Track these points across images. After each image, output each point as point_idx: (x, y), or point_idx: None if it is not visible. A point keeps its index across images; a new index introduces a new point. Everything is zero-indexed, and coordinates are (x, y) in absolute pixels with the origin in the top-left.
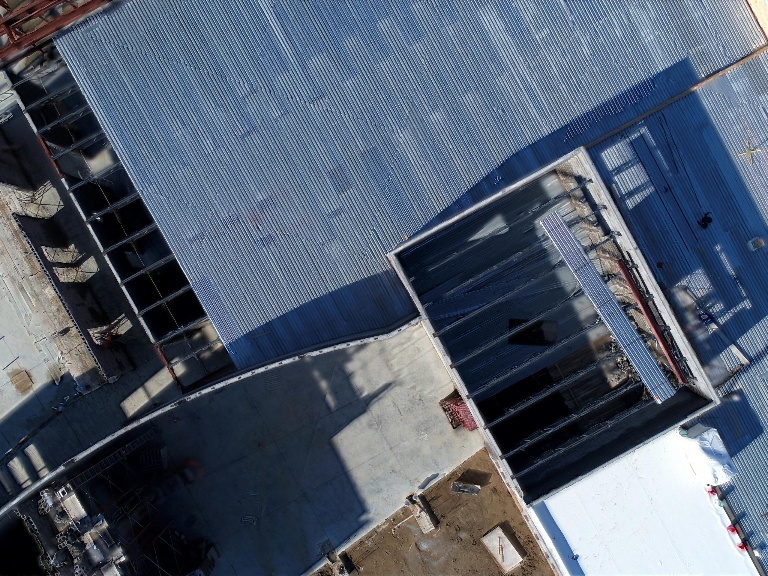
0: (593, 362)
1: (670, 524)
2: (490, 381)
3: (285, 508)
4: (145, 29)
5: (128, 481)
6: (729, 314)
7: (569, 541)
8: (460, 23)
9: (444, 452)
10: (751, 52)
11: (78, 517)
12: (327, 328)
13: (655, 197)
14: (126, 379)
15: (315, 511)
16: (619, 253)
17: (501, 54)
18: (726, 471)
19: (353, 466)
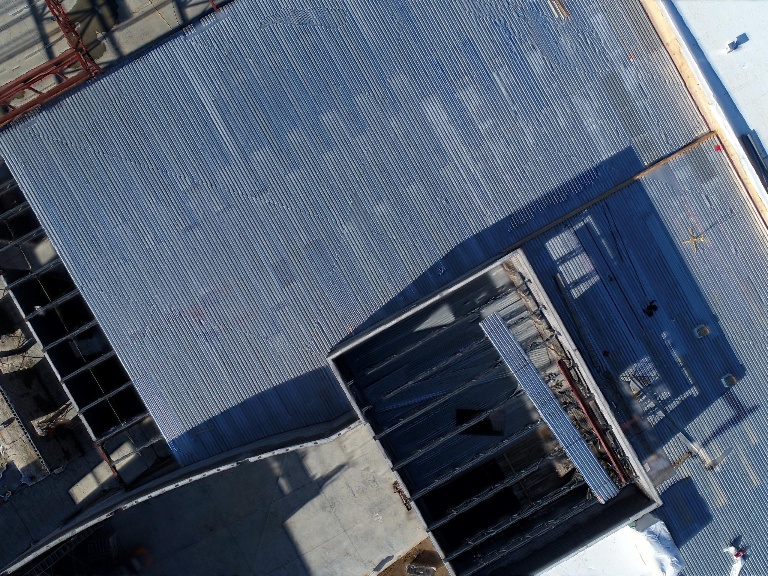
0: (541, 452)
1: None
2: (432, 484)
3: None
4: (84, 124)
5: (75, 574)
6: (676, 402)
7: None
8: (402, 114)
9: (399, 534)
10: (693, 140)
11: None
12: (272, 423)
13: (600, 286)
14: (75, 465)
15: None
16: (562, 349)
17: (444, 145)
18: (674, 565)
19: (307, 550)
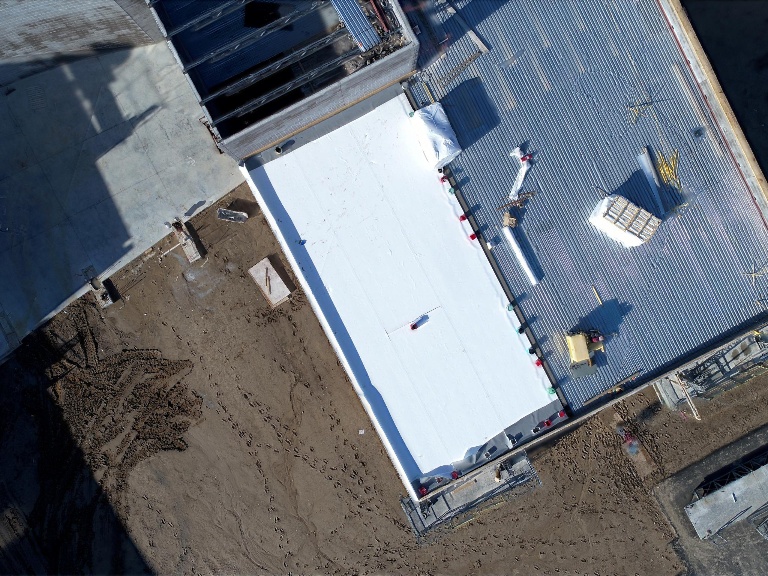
0: (330, 47)
1: (401, 213)
2: None
3: (48, 232)
4: None
5: None
6: None
7: (297, 226)
8: None
9: (212, 179)
10: None
11: None
12: None
13: None
14: None
15: (79, 236)
16: None
17: None
18: (448, 145)
19: (118, 190)
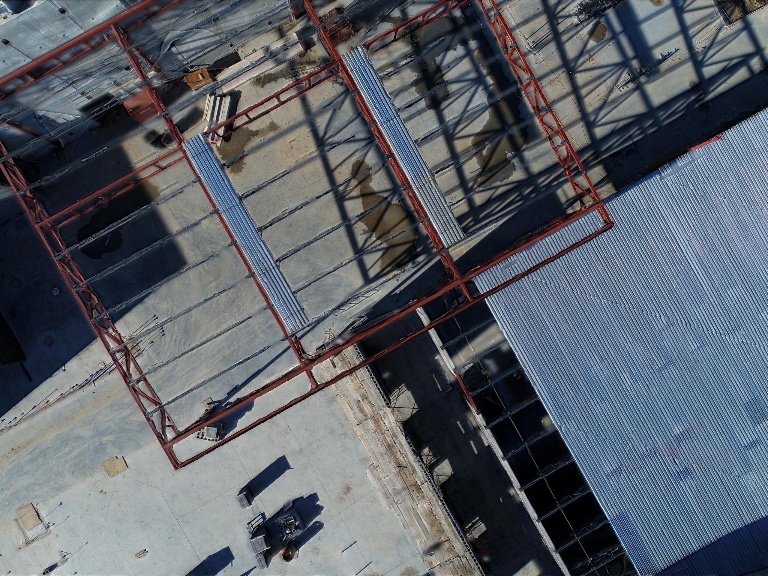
0: None
1: None
2: None
3: None
4: (563, 264)
5: None
6: None
7: None
8: None
9: None
10: None
11: None
12: (744, 561)
13: None
14: None
15: None
16: None
17: None
18: None
19: None
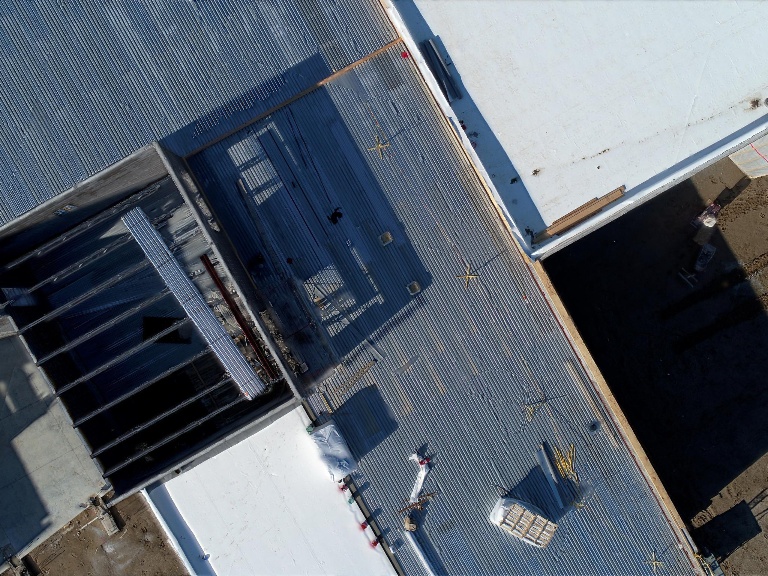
0: None
1: (304, 522)
2: (77, 379)
3: None
4: None
5: None
6: (361, 309)
7: (200, 541)
8: (84, 19)
9: None
10: None
11: None
12: None
13: (284, 193)
14: None
15: None
16: None
17: (127, 50)
18: (342, 467)
19: (34, 468)
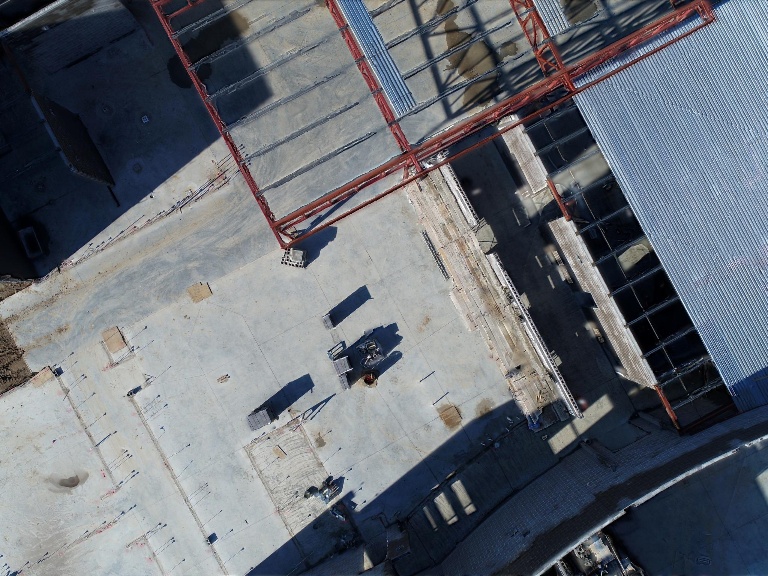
0: None
1: None
2: None
3: (709, 547)
4: (655, 75)
5: None
6: None
7: None
8: None
9: None
10: None
11: (606, 560)
12: None
13: None
14: None
15: (739, 550)
16: None
17: None
18: None
19: None
